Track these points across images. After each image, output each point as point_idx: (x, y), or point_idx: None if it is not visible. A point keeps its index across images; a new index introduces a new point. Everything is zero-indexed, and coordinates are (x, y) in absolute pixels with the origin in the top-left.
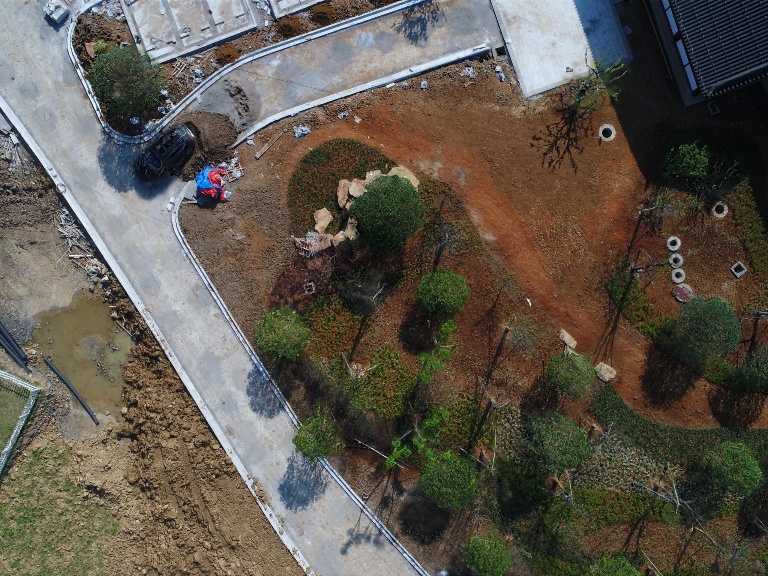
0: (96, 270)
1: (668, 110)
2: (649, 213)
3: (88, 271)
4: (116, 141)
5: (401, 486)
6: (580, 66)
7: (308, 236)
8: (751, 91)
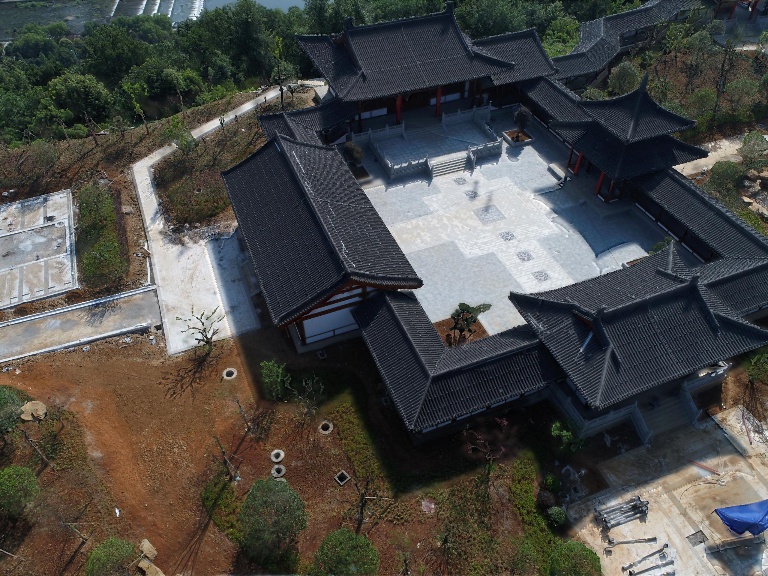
0: None
1: (285, 358)
2: (255, 430)
3: None
4: None
5: None
6: (218, 333)
7: None
8: (354, 343)
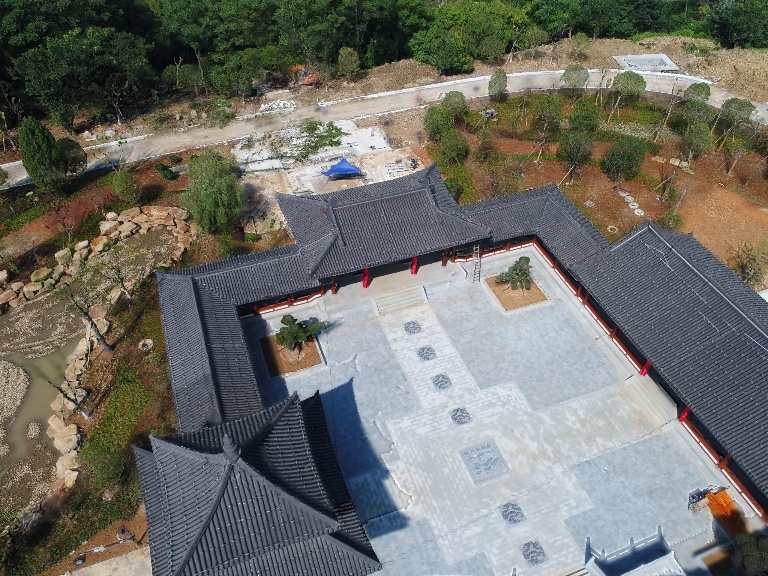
0: None
1: None
2: None
3: None
4: None
5: None
6: None
7: None
8: None
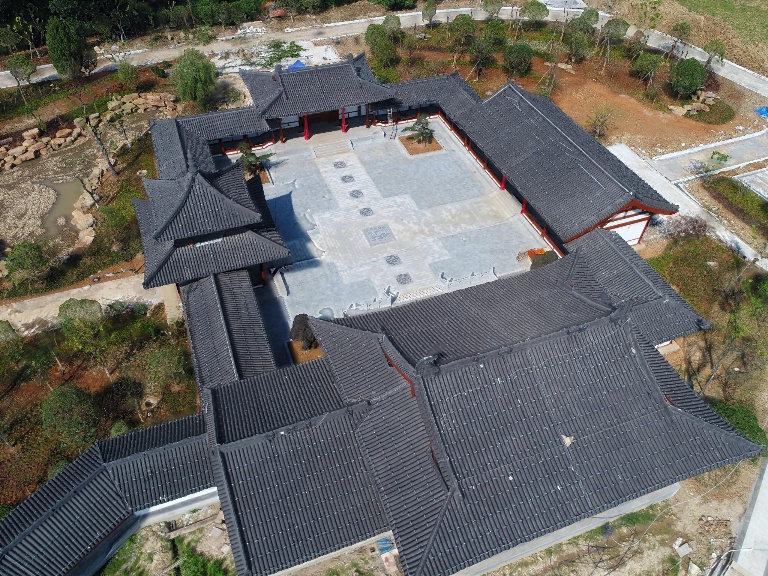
0: None
1: None
2: None
3: None
4: None
5: None
6: None
7: None
8: None
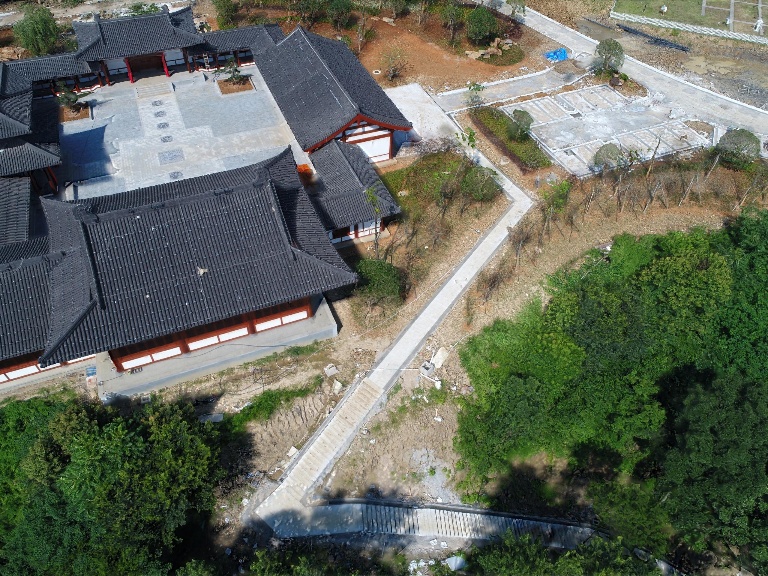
0: None
1: None
2: None
3: None
4: None
5: (455, 1)
6: None
7: (512, 41)
8: None
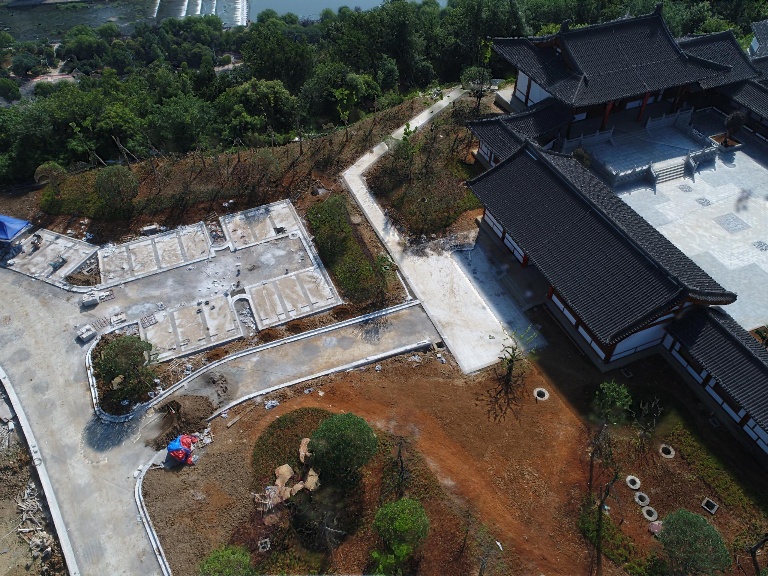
0: (41, 542)
1: (589, 376)
2: (599, 455)
3: (32, 544)
4: (103, 421)
5: None
6: None
7: (268, 488)
8: (654, 360)
